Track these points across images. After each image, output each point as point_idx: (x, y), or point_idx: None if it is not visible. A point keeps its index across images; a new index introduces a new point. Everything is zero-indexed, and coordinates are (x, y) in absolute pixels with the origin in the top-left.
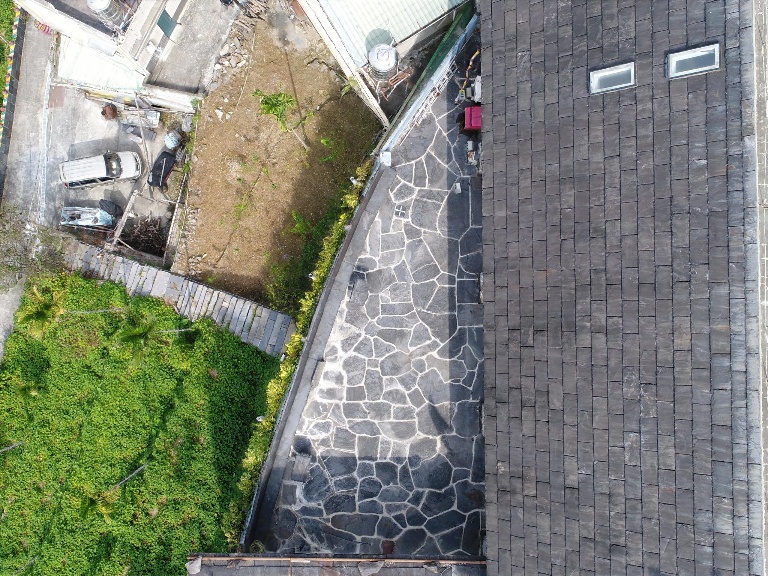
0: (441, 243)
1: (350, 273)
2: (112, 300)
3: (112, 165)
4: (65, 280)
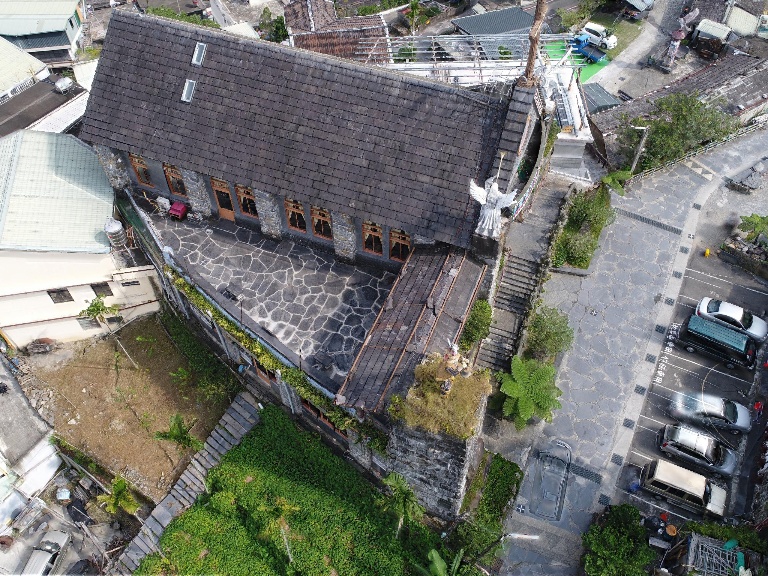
0: (235, 250)
1: (221, 294)
2: (150, 574)
3: None
4: None
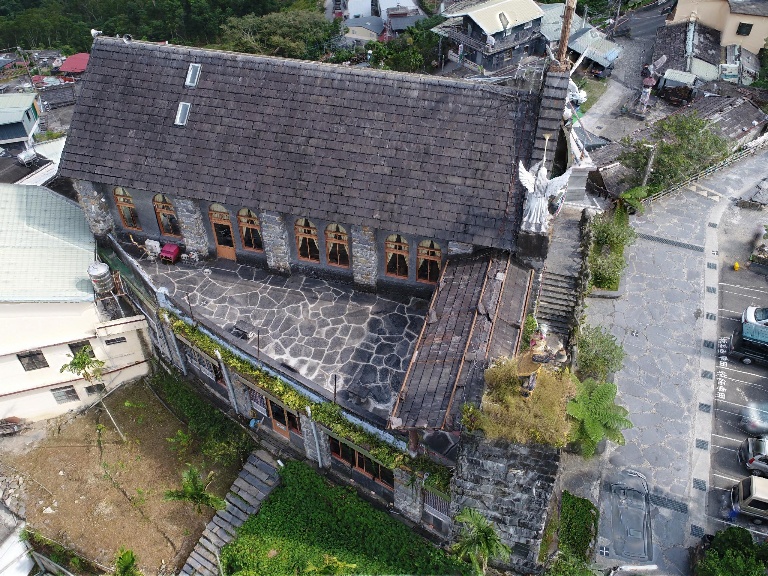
0: (238, 288)
1: (229, 333)
2: None
3: None
4: None
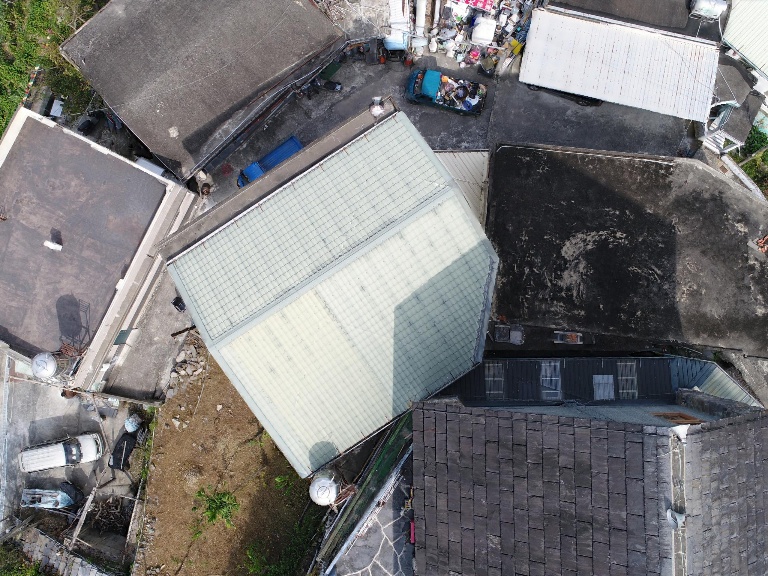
0: None
1: None
2: None
3: (72, 450)
4: (25, 573)
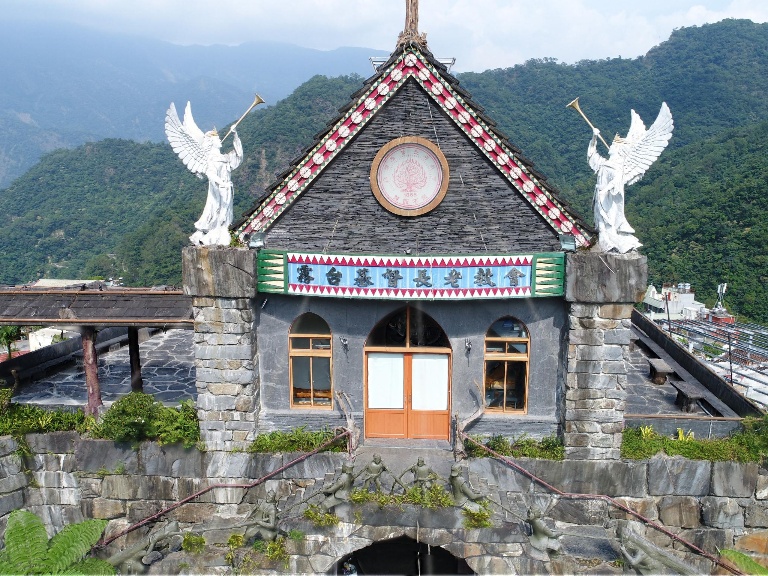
0: None
1: None
2: None
3: None
4: None
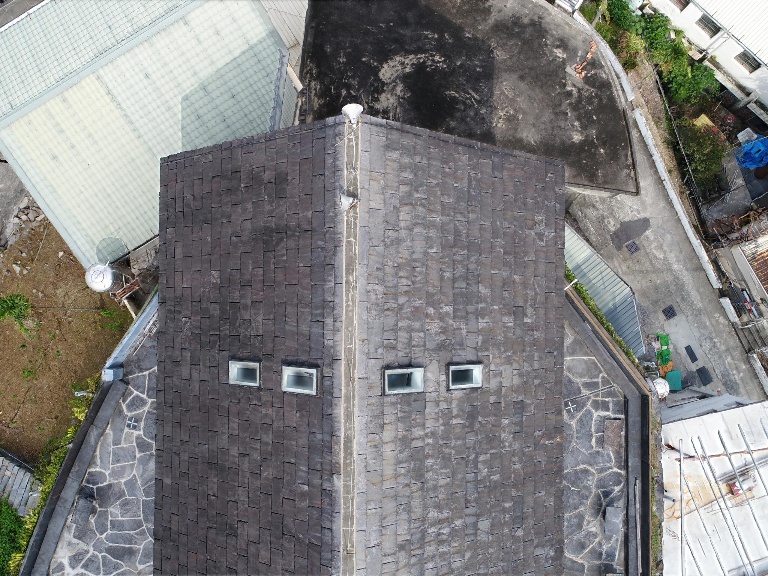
0: None
1: (75, 490)
2: None
3: None
4: None
